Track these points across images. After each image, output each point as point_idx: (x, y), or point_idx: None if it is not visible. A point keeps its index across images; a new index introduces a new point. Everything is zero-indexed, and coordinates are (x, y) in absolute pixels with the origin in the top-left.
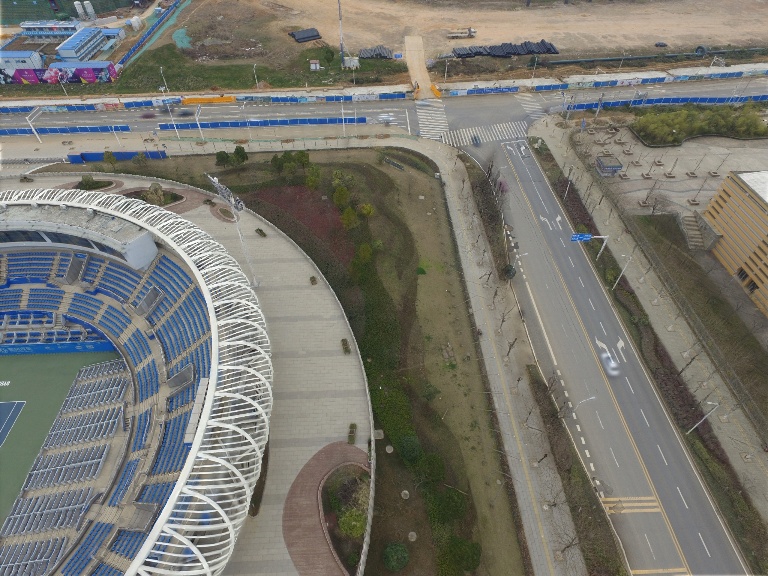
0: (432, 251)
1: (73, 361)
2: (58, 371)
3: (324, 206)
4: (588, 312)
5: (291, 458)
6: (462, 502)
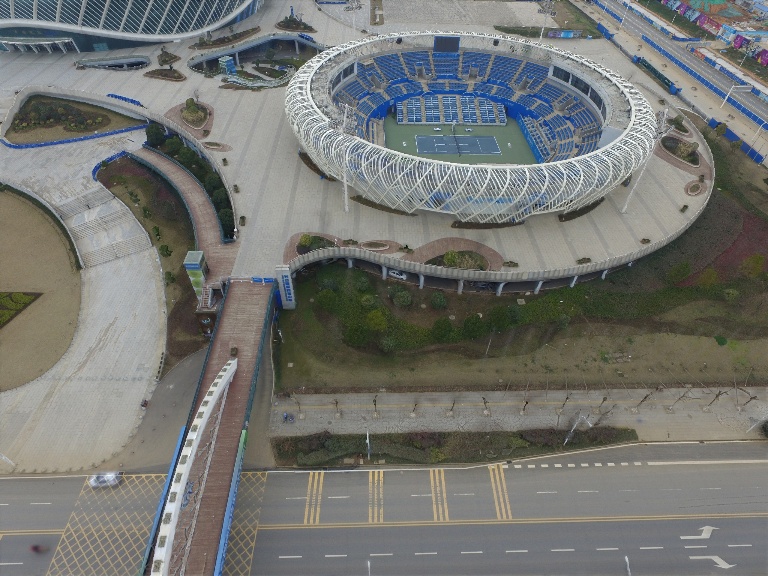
0: (764, 355)
1: (531, 163)
2: (523, 159)
3: (767, 259)
4: (763, 533)
5: (487, 238)
6: (474, 325)
